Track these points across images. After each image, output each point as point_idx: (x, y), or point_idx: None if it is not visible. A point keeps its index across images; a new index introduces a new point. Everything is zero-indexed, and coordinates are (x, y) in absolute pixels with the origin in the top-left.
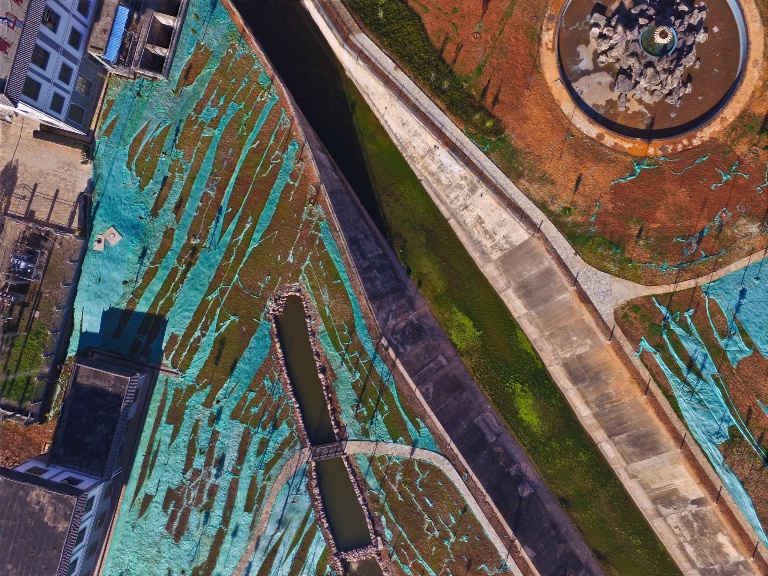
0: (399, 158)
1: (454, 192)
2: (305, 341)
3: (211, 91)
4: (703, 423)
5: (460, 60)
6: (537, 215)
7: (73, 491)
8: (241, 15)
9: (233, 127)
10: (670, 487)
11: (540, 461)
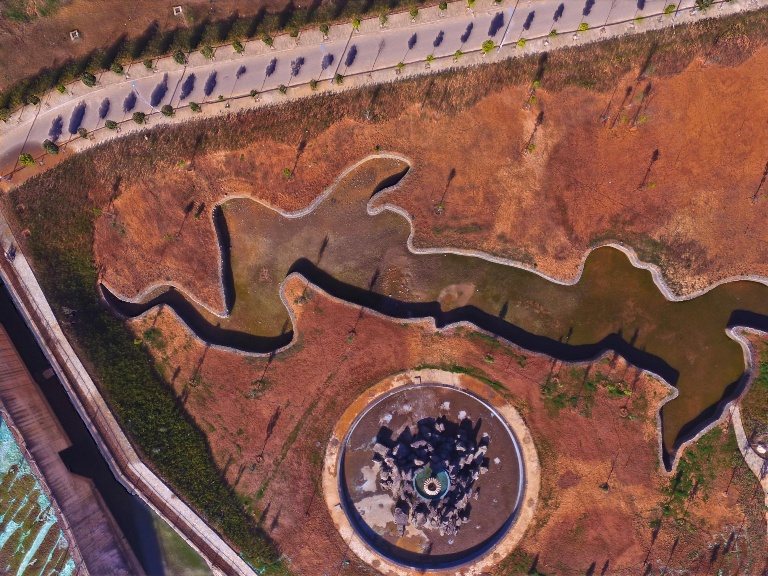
0: None
1: None
2: None
3: None
4: None
5: (242, 481)
6: None
7: None
8: None
9: (12, 545)
10: None
11: None
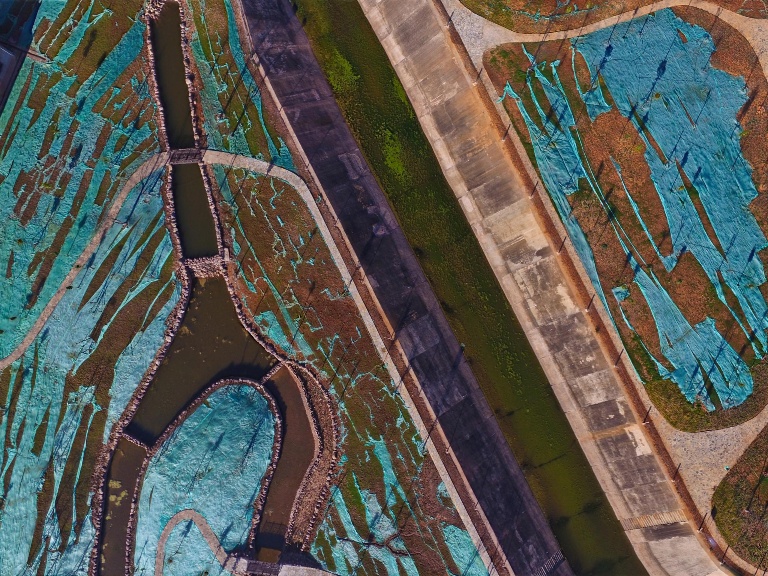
0: None
1: None
2: (177, 47)
3: None
4: (555, 173)
5: None
6: None
7: None
8: None
9: None
10: (519, 239)
11: (400, 209)
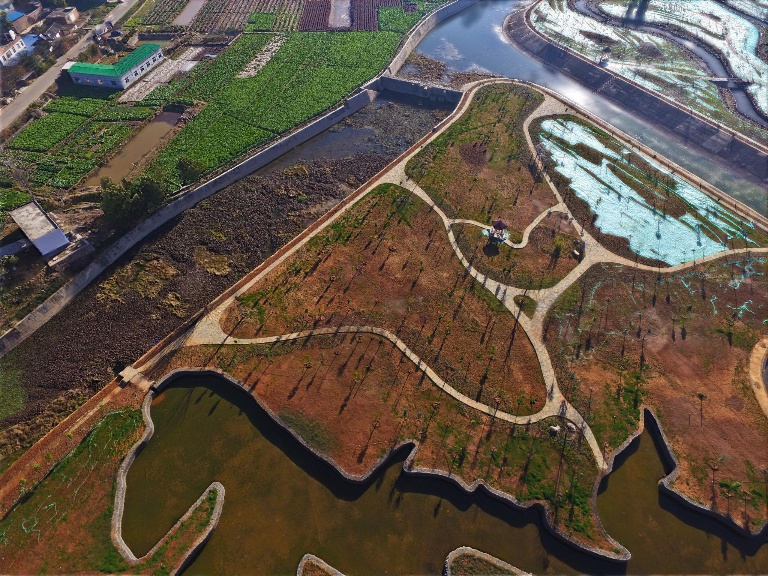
0: None
1: None
2: None
3: None
4: (694, 192)
5: None
6: None
7: None
8: None
9: None
10: None
11: (763, 193)
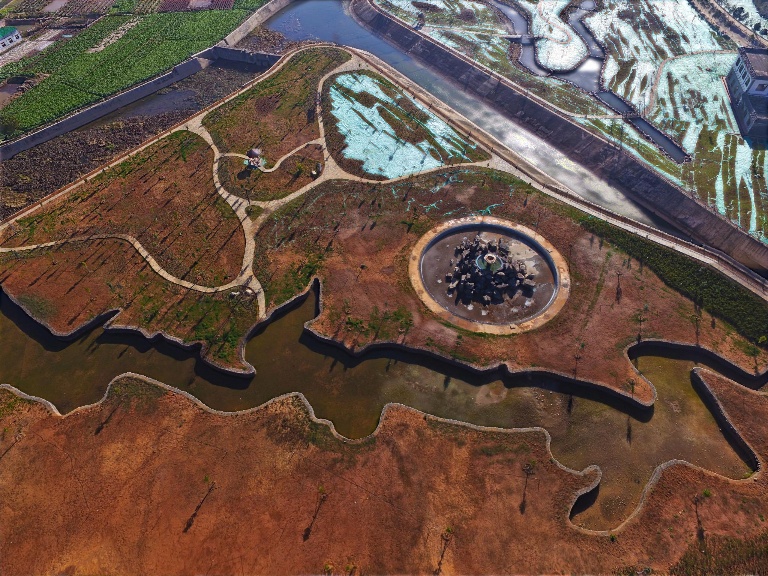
0: None
1: None
2: None
3: None
4: (440, 125)
5: None
6: (547, 191)
7: (760, 78)
8: None
9: None
10: None
11: (511, 125)
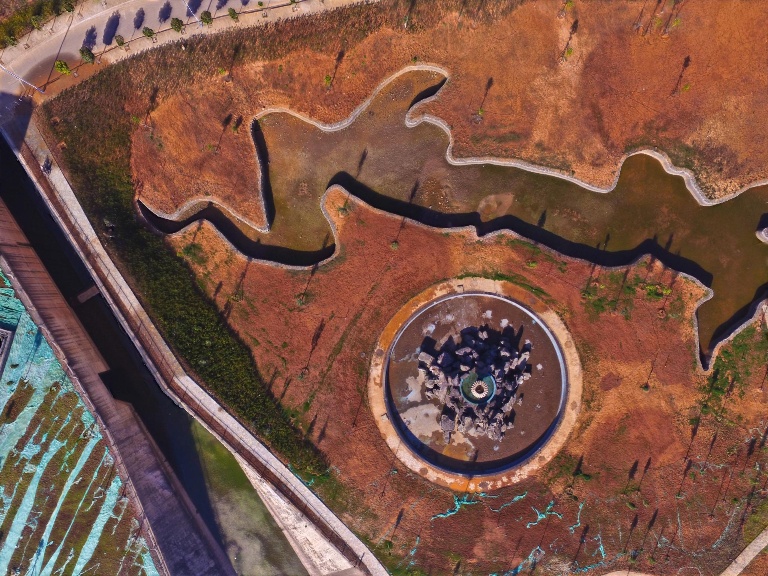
0: (236, 467)
1: (283, 513)
2: None
3: (33, 429)
4: None
5: (288, 394)
6: (359, 547)
7: None
8: (77, 329)
9: (55, 464)
10: None
11: None
